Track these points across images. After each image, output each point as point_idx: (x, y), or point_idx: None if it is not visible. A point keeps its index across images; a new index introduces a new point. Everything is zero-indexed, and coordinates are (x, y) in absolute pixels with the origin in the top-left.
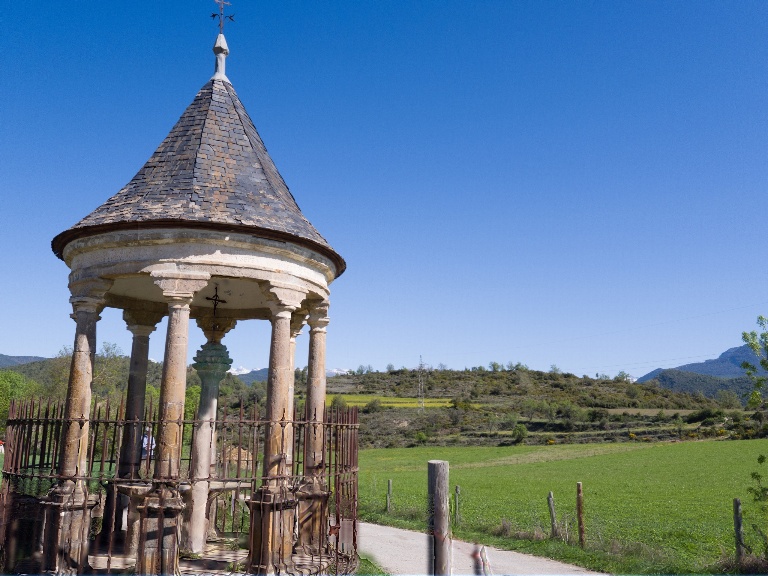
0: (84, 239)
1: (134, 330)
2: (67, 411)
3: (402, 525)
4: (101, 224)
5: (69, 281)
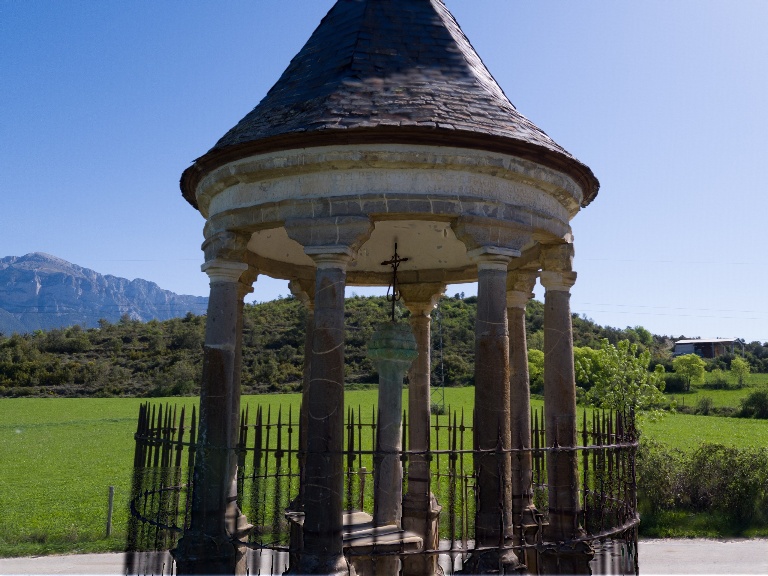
0: (526, 162)
1: (235, 270)
2: (503, 431)
3: (6, 553)
4: (574, 160)
5: (436, 204)
